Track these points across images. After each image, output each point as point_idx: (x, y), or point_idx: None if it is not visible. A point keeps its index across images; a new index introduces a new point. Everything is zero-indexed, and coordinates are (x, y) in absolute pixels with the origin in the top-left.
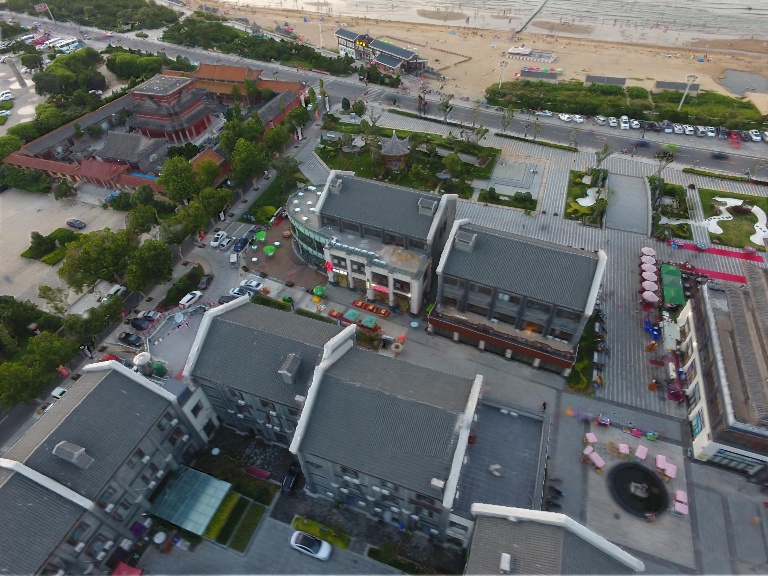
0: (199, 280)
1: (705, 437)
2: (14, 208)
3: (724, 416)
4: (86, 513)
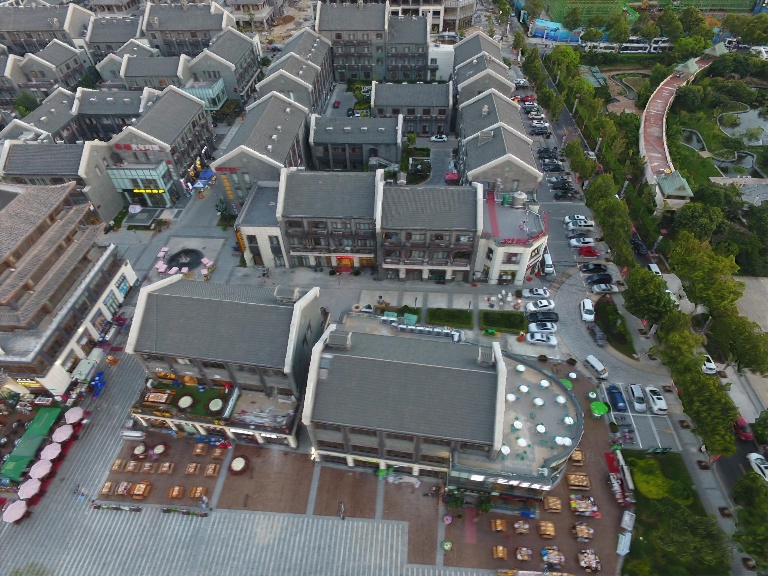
0: None
1: None
2: None
3: None
4: None
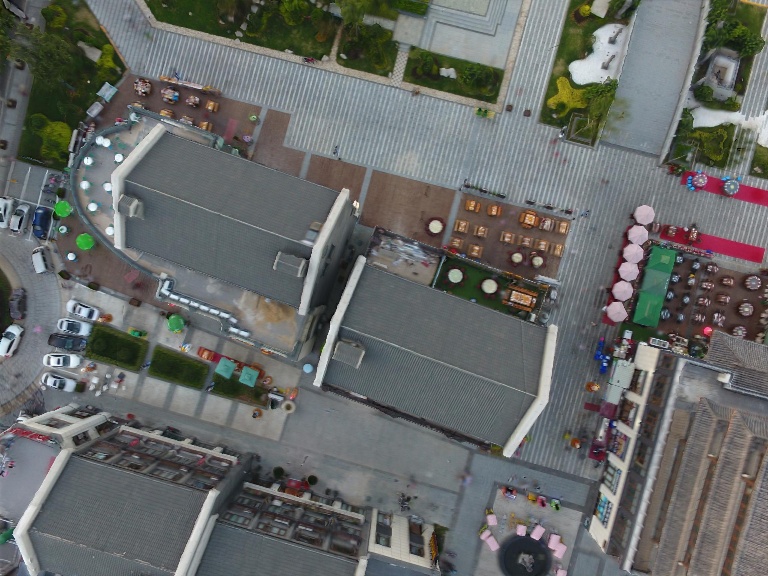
0: (8, 306)
1: (602, 540)
2: None
3: (623, 556)
4: None
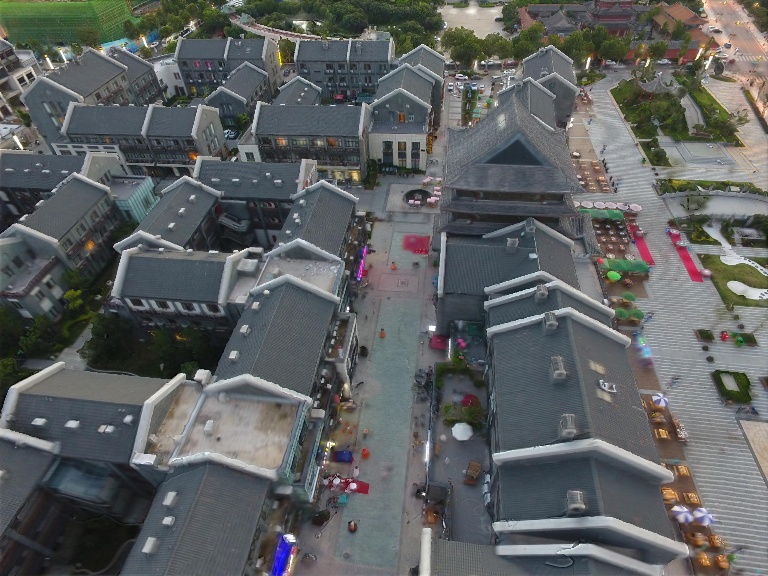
0: None
1: None
2: (491, 28)
3: None
4: (346, 62)
